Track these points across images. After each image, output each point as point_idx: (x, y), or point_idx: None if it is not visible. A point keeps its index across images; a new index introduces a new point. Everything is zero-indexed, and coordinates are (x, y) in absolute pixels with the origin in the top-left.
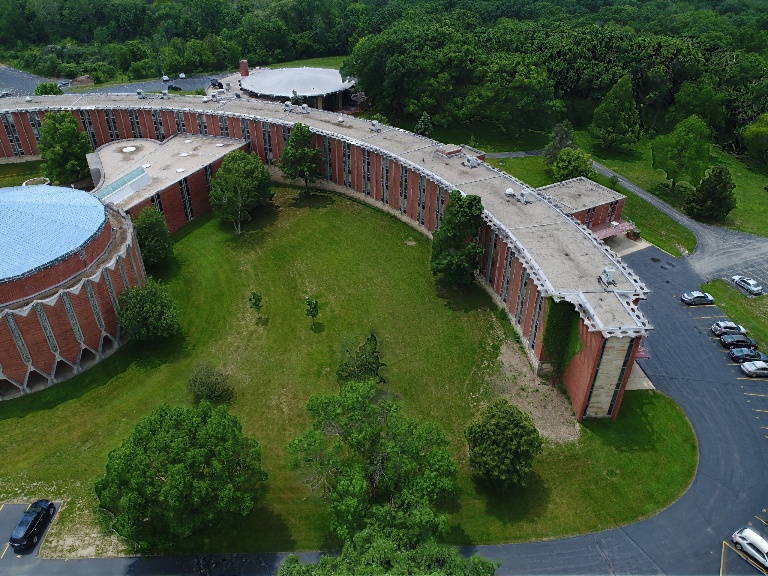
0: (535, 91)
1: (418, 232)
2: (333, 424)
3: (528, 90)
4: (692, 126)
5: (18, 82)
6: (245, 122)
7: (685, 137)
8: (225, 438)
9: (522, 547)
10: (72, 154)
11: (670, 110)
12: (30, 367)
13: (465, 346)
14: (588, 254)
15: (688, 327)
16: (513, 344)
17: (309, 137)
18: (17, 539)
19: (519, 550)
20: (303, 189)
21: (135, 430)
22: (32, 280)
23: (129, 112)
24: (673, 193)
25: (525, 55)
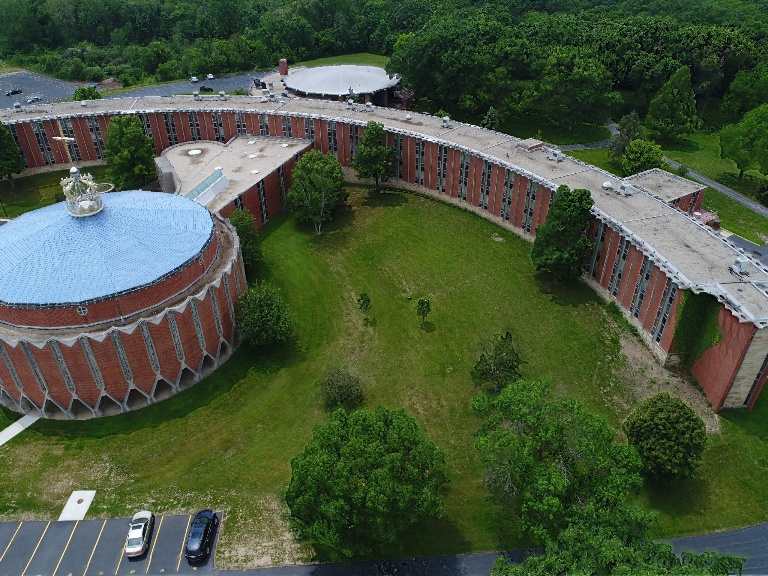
0: (593, 83)
1: (501, 228)
2: (519, 424)
3: (587, 83)
4: (764, 115)
5: (44, 87)
6: (310, 122)
7: (757, 126)
8: (415, 441)
9: (697, 540)
10: (138, 158)
11: (717, 99)
12: (158, 376)
13: (583, 341)
14: (709, 245)
15: None
16: (631, 337)
17: (383, 135)
18: (194, 551)
19: (695, 543)
20: (371, 188)
21: (322, 436)
22: (160, 287)
23: (189, 114)
24: (741, 182)
25: (580, 48)
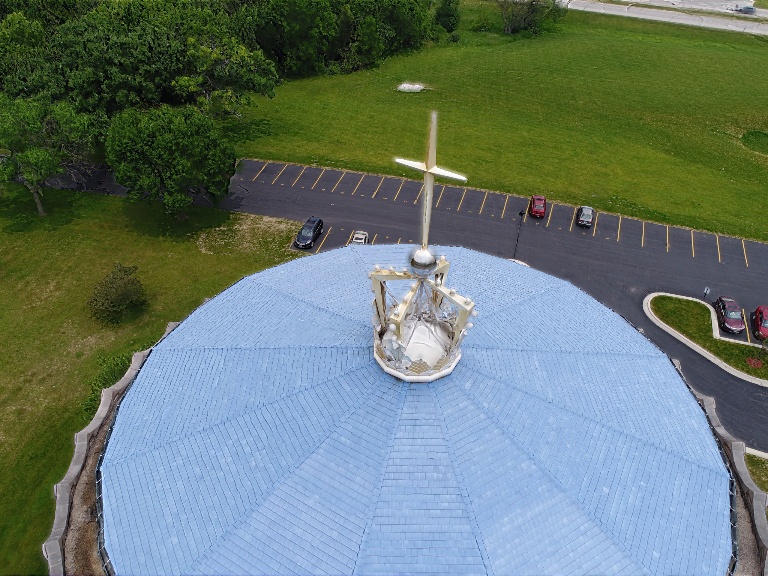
0: None
1: None
2: None
3: None
4: None
5: None
6: None
7: None
8: None
9: None
10: None
11: None
12: None
13: None
14: None
15: None
16: None
17: None
18: None
19: None
20: None
21: None
22: None
23: None
24: None
25: None
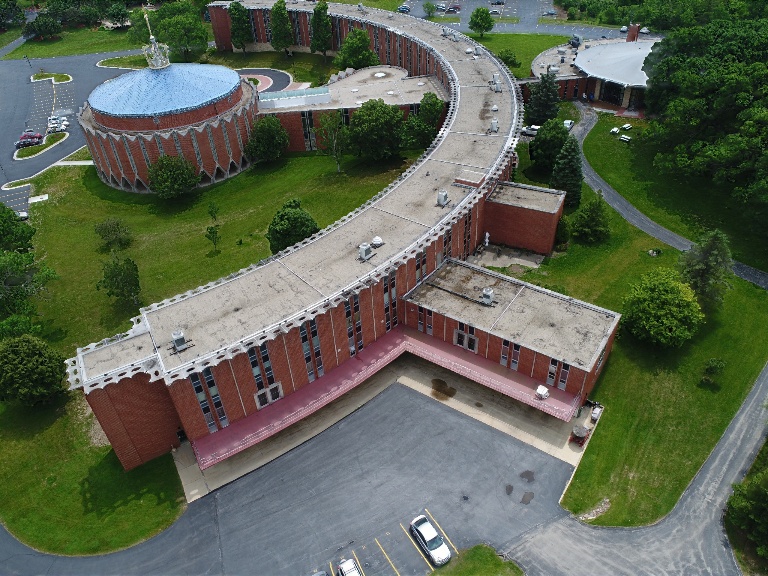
0: None
1: None
2: None
3: None
4: None
5: (527, 4)
6: None
7: None
8: None
9: None
10: None
11: None
12: (111, 171)
13: None
14: (243, 324)
15: (346, 532)
16: None
17: (431, 111)
18: None
19: None
20: None
21: None
22: (121, 121)
23: None
24: None
25: None
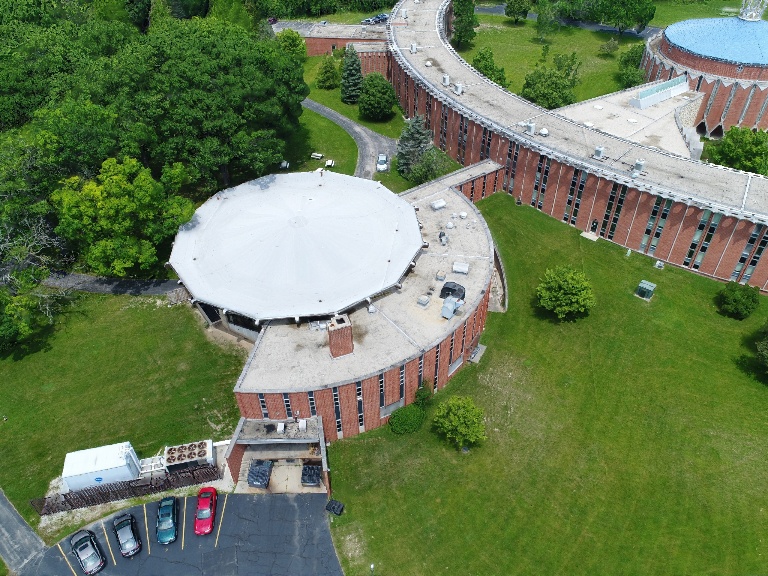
0: None
1: None
2: None
3: None
4: None
5: None
6: None
7: None
8: None
9: None
10: None
11: None
12: None
13: None
14: None
15: None
16: None
17: None
18: None
19: None
20: None
21: None
22: None
23: None
24: None
25: None
